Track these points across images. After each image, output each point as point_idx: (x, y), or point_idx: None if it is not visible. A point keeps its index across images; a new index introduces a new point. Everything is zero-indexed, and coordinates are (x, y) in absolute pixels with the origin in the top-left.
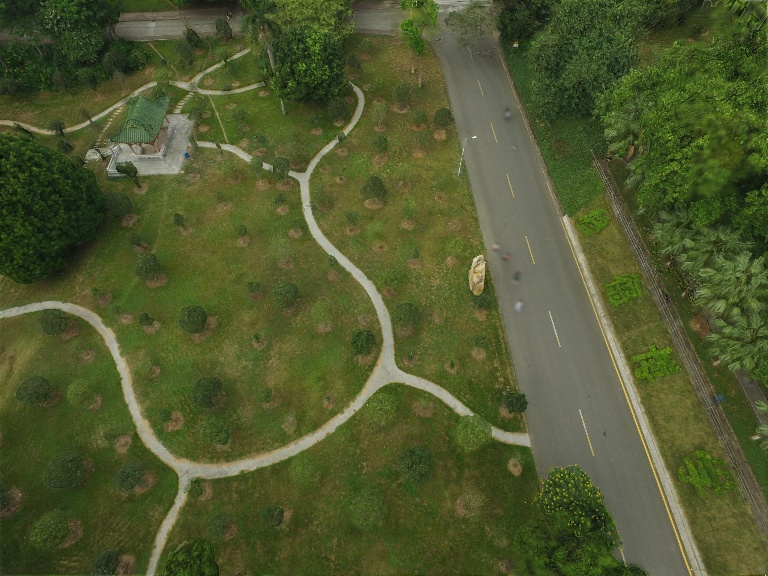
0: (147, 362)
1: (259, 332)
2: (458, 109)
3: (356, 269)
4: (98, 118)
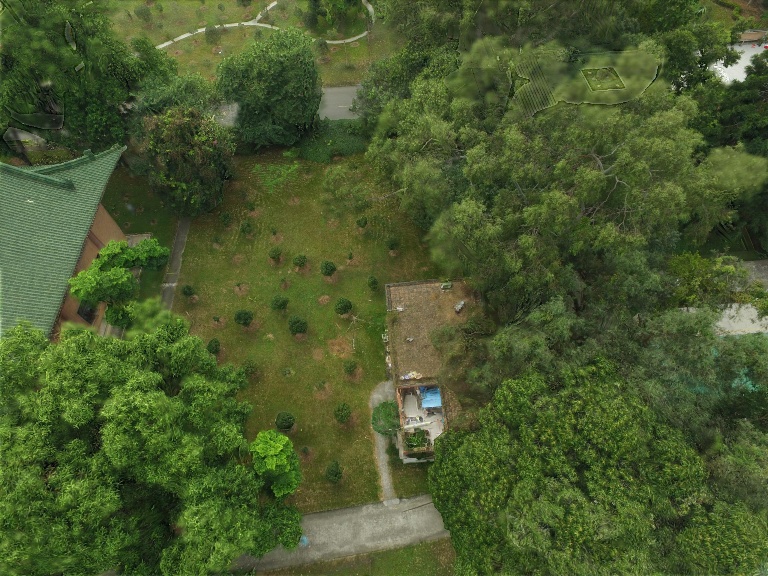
0: None
1: None
2: None
3: (165, 45)
4: None
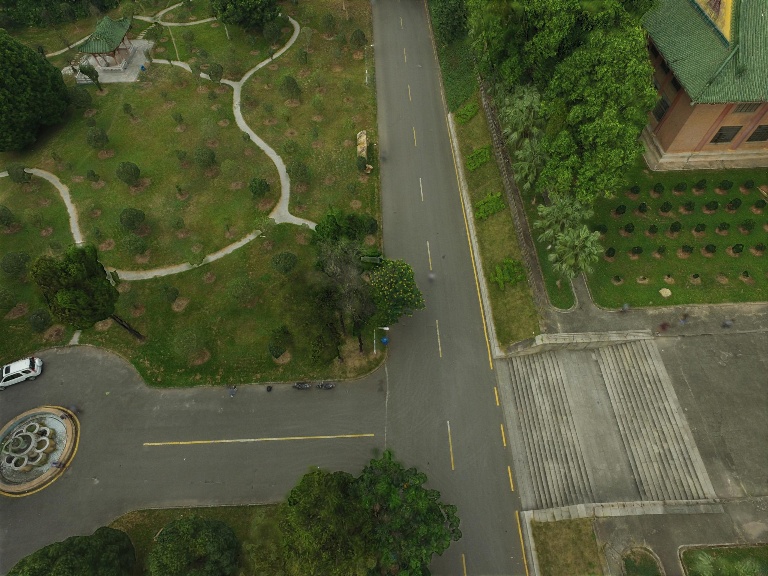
0: (90, 204)
1: (183, 188)
2: (378, 38)
3: (269, 148)
4: (75, 45)
